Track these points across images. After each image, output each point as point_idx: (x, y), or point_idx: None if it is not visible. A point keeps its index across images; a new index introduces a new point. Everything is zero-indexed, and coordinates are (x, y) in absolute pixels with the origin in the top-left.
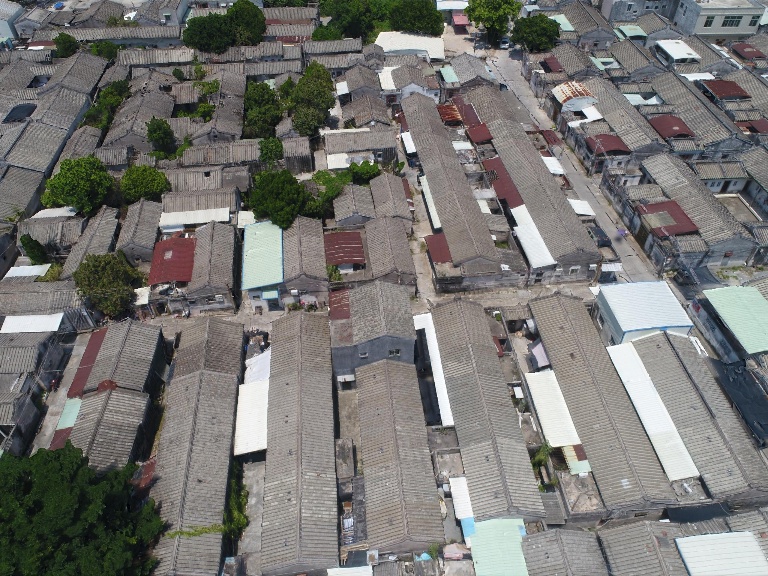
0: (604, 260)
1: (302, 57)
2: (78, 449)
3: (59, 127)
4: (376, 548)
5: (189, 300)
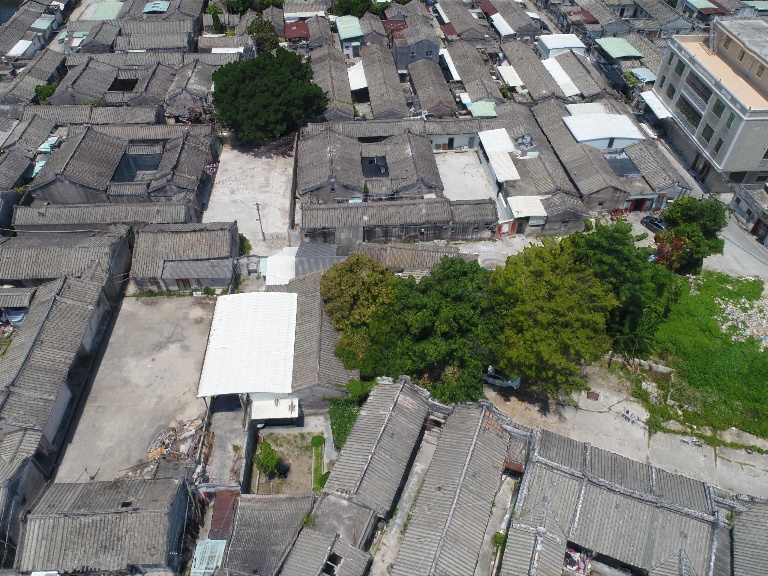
0: (543, 33)
1: None
2: None
3: None
4: (426, 109)
5: (310, 47)
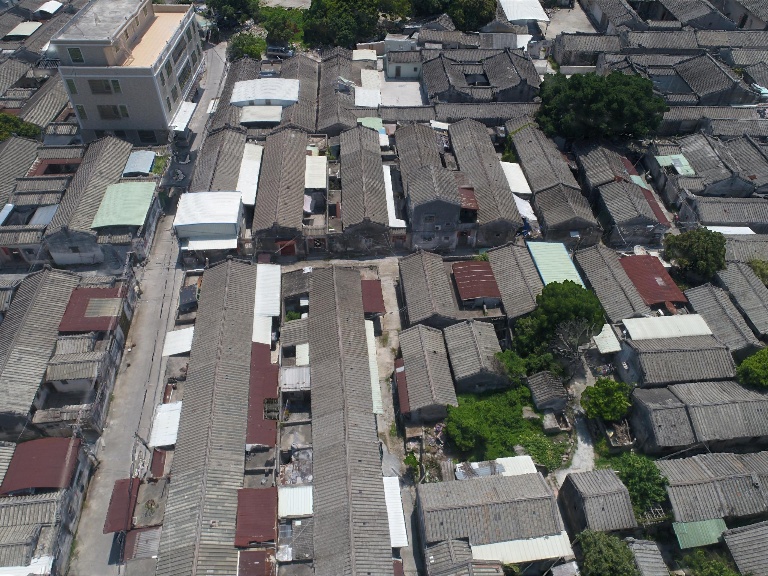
0: None
1: None
2: (594, 107)
3: None
4: None
5: None
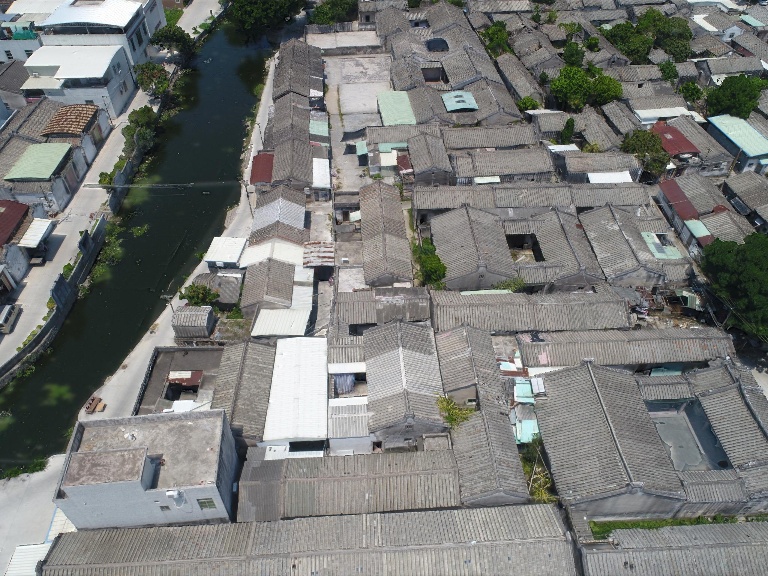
0: None
1: (616, 8)
2: None
3: (485, 54)
4: None
5: (703, 166)
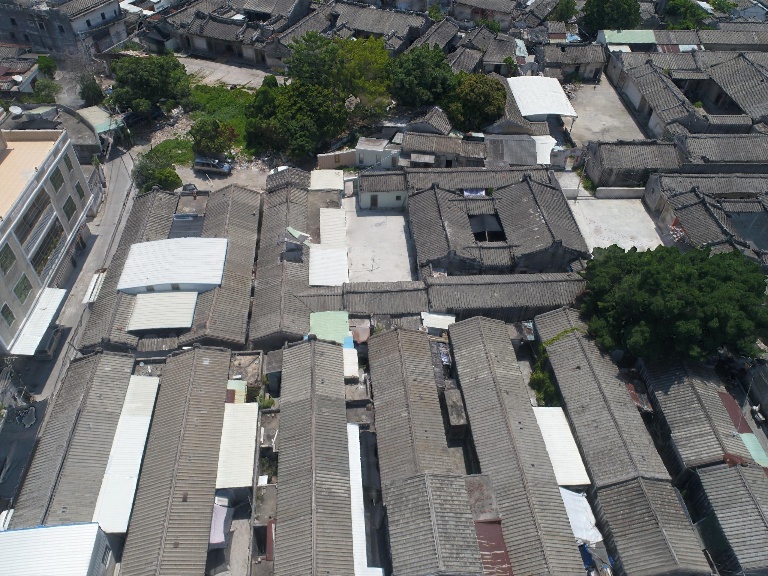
0: None
1: None
2: (683, 329)
3: None
4: None
5: None
